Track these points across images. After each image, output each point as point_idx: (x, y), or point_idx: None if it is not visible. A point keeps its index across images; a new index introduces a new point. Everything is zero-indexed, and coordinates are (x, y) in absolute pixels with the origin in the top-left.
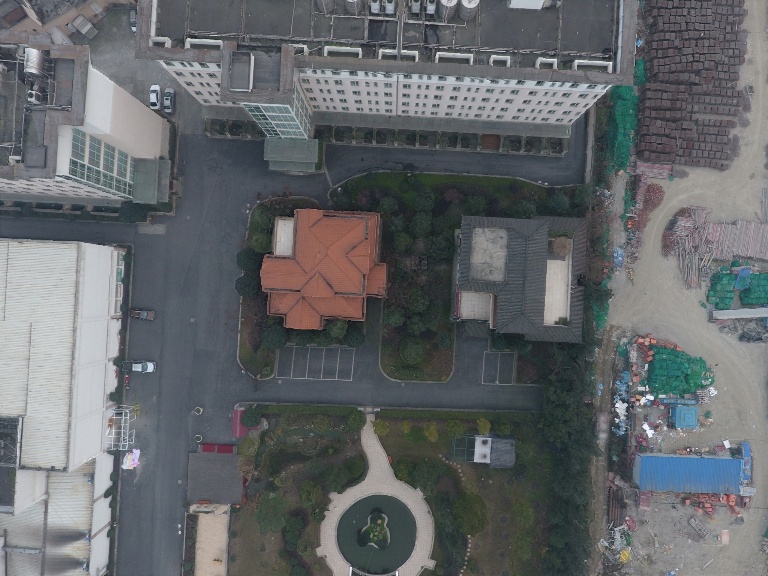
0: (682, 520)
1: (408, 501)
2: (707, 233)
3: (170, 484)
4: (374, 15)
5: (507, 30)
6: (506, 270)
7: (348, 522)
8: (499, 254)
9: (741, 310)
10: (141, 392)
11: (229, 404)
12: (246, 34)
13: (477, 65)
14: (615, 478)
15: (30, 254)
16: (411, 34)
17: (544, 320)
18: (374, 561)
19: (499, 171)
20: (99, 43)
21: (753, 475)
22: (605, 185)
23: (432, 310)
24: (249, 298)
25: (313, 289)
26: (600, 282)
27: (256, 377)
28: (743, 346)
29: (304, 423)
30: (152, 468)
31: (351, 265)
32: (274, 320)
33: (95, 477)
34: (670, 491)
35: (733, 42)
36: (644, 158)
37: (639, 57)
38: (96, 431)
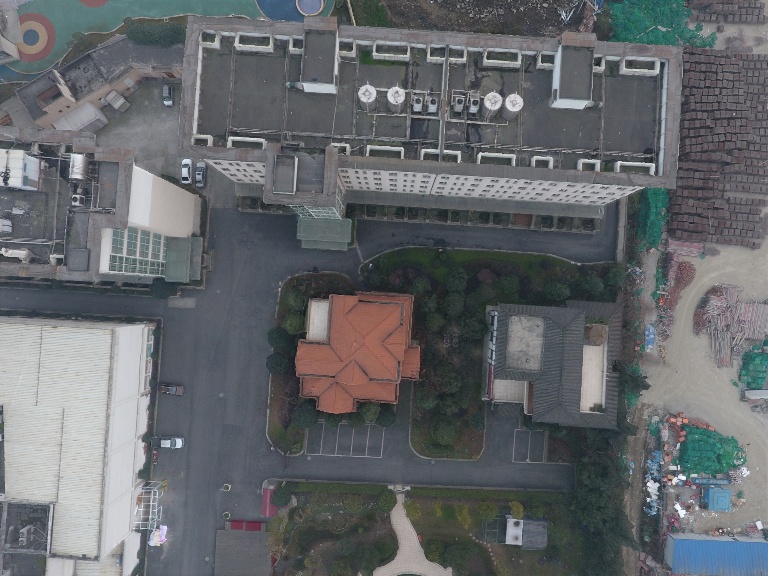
0: None
1: None
2: (739, 312)
3: (197, 561)
4: (416, 113)
5: (549, 129)
6: (542, 359)
7: None
8: (535, 342)
9: None
10: (169, 467)
11: (257, 480)
12: (288, 132)
13: (520, 167)
14: (646, 558)
15: (64, 339)
16: (453, 132)
17: None
18: None
19: (530, 247)
20: (131, 116)
21: None
22: (637, 262)
23: (463, 388)
24: None
25: (348, 377)
26: (632, 360)
27: (286, 455)
28: None
29: (333, 500)
30: (179, 545)
31: (386, 352)
32: (304, 398)
33: (123, 559)
34: None
35: (765, 121)
36: (676, 236)
37: None
38: (125, 512)
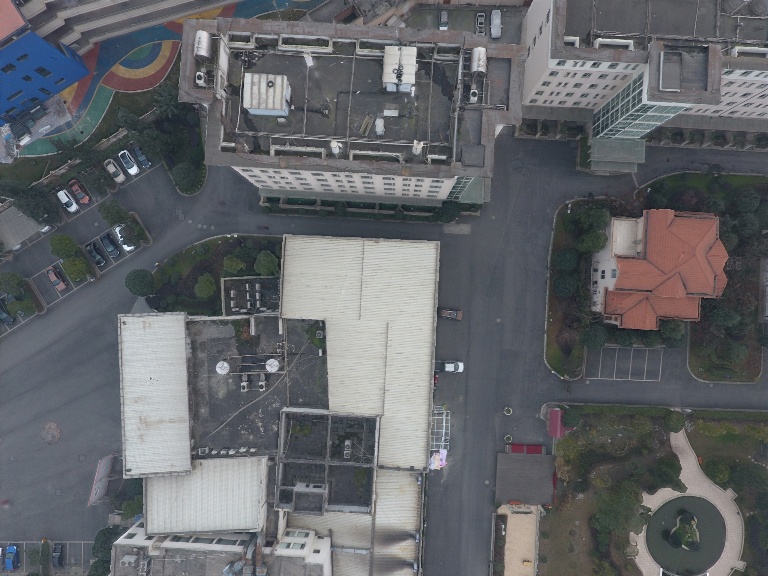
0: None
1: (717, 502)
2: None
3: (477, 484)
4: None
5: None
6: None
7: (657, 523)
8: None
9: None
10: (448, 392)
11: (536, 404)
12: (652, 34)
13: None
14: None
15: (387, 253)
16: None
17: None
18: (683, 562)
19: None
20: None
21: None
22: None
23: None
24: (557, 298)
25: (672, 289)
26: None
27: None
28: None
29: None
30: (459, 468)
31: (708, 265)
32: None
33: None
34: None
35: None
36: None
37: None
38: None
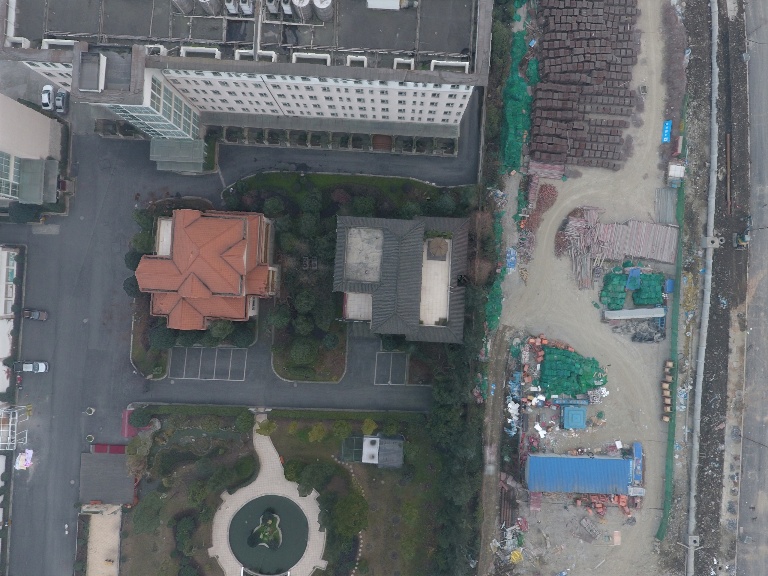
0: (574, 520)
1: (300, 501)
2: (598, 233)
3: (63, 484)
4: (233, 15)
5: (366, 30)
6: (381, 270)
7: (240, 522)
8: (374, 254)
9: (632, 310)
10: (34, 392)
11: (122, 404)
12: (104, 34)
13: None
14: (507, 478)
15: None
16: (270, 34)
17: (424, 320)
18: (266, 561)
19: (392, 171)
20: None
21: (645, 475)
22: (498, 185)
23: (323, 310)
24: (142, 298)
25: (188, 289)
26: (492, 282)
27: (146, 377)
28: (636, 346)
29: (196, 423)
30: (45, 468)
31: (226, 265)
32: (164, 320)
33: None
34: (558, 491)
35: (625, 42)
36: (536, 158)
37: (533, 57)
38: None
